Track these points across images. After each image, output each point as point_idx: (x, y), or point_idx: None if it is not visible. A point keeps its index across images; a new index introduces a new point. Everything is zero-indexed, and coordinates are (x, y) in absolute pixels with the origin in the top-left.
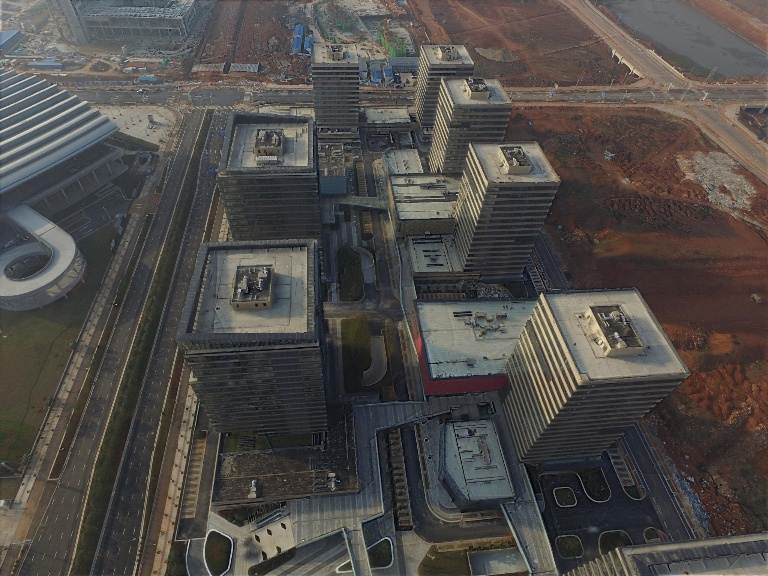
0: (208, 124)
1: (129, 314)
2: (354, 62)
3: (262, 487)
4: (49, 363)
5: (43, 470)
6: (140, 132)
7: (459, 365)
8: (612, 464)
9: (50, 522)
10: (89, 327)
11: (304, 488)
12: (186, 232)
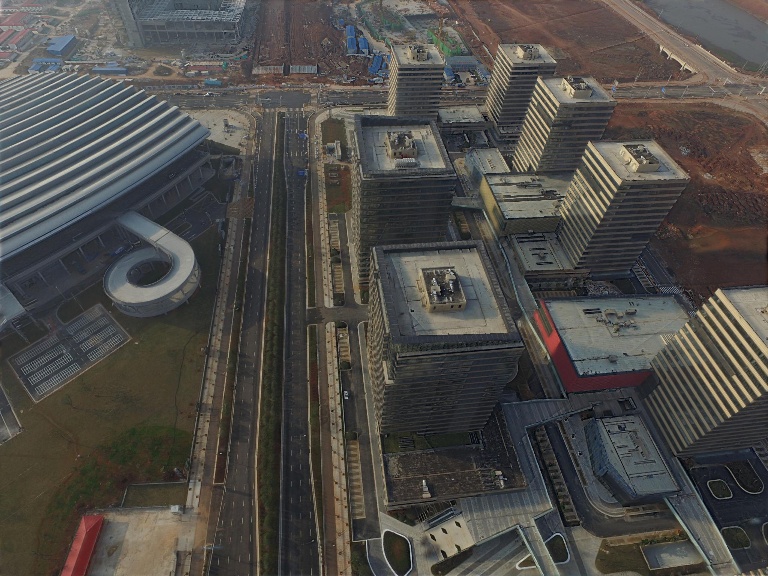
0: (283, 127)
1: (252, 318)
2: (439, 63)
3: (432, 486)
4: (186, 368)
5: (206, 475)
6: (217, 136)
7: (602, 362)
8: (758, 456)
9: (226, 526)
10: (216, 332)
11: (474, 486)
12: (288, 235)
